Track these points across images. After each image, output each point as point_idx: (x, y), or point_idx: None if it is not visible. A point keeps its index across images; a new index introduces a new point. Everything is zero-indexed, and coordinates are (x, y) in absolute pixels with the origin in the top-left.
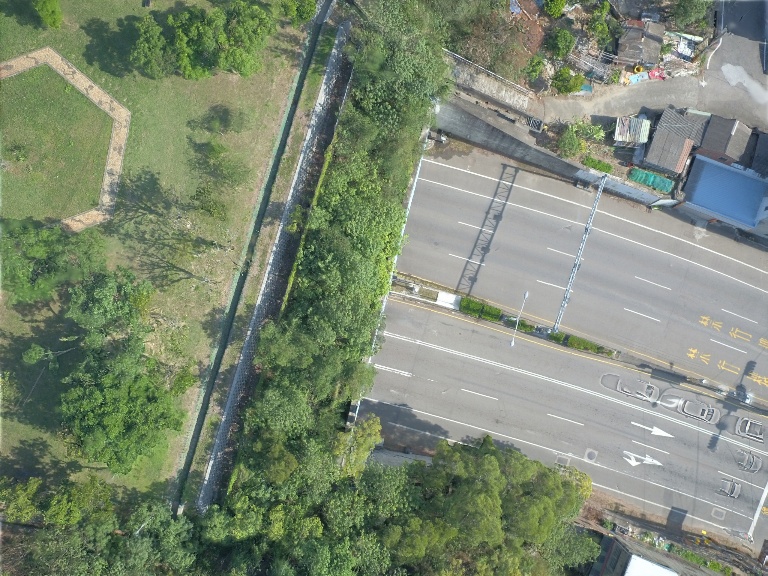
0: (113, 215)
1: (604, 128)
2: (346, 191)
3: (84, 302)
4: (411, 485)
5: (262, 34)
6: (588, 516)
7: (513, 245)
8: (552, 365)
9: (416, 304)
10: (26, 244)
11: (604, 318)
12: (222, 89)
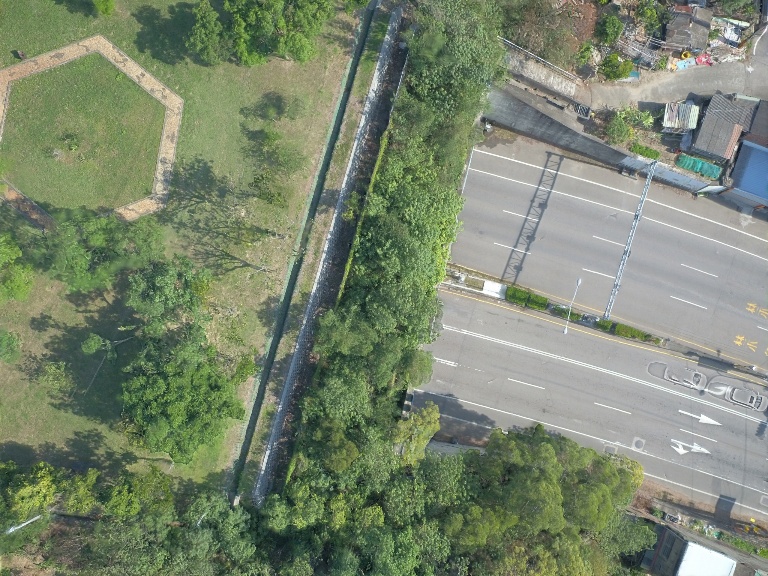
0: (166, 204)
1: (652, 114)
2: (402, 178)
3: (144, 290)
4: (469, 474)
5: (321, 19)
6: (637, 505)
7: (558, 233)
8: (599, 354)
9: (461, 293)
10: (86, 232)
11: (650, 306)
12: (275, 76)
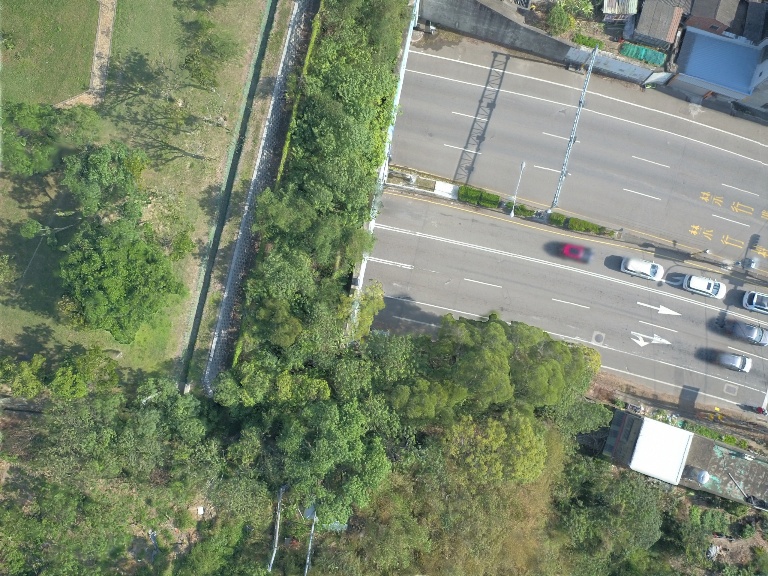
0: (104, 98)
1: (592, 3)
2: (336, 59)
3: (79, 171)
4: (417, 353)
5: None
6: (599, 397)
7: (508, 132)
8: (554, 250)
9: (414, 196)
10: (18, 115)
11: (604, 200)
12: None
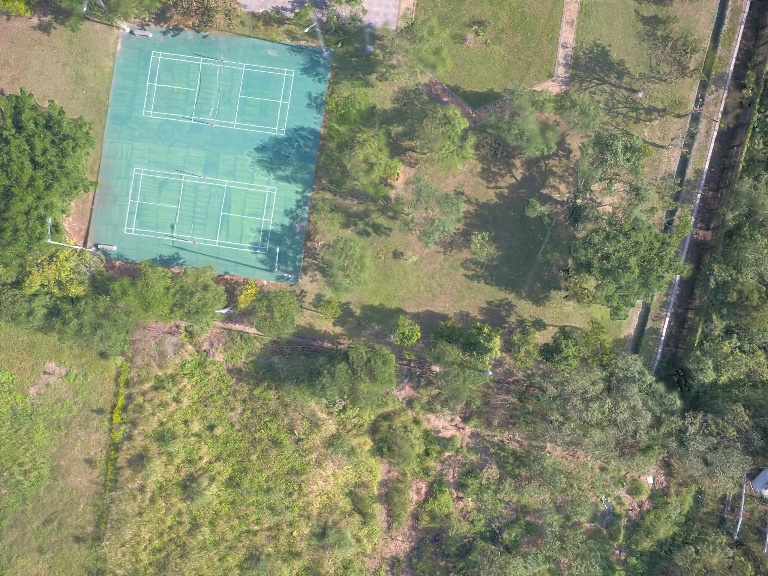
0: (569, 86)
1: None
2: None
3: None
4: None
5: None
6: None
7: None
8: None
9: None
10: (538, 100)
11: None
12: None
